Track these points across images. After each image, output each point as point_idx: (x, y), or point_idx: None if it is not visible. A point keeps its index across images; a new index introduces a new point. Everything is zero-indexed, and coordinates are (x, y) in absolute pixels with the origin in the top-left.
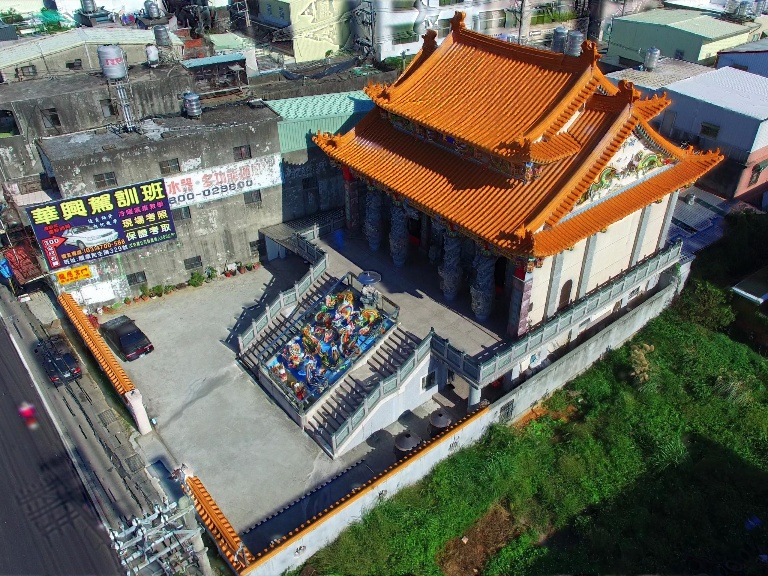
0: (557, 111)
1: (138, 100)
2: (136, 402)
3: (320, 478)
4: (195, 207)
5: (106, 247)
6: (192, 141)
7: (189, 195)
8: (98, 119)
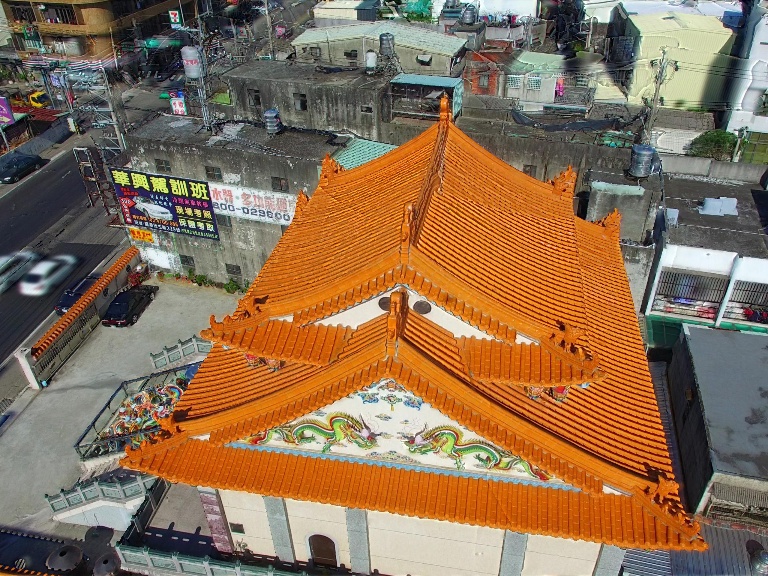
0: (325, 291)
1: (325, 102)
2: (22, 359)
3: (26, 525)
4: (236, 219)
5: (165, 223)
6: (233, 156)
7: (231, 206)
8: (290, 109)
